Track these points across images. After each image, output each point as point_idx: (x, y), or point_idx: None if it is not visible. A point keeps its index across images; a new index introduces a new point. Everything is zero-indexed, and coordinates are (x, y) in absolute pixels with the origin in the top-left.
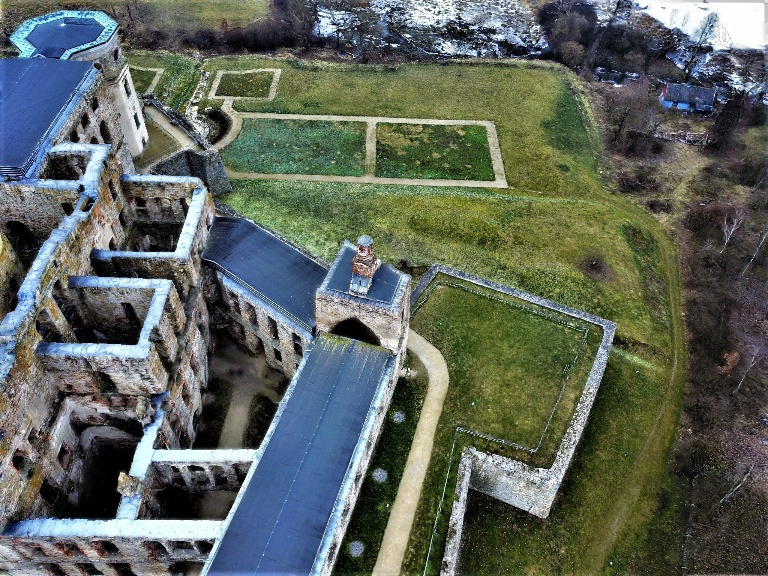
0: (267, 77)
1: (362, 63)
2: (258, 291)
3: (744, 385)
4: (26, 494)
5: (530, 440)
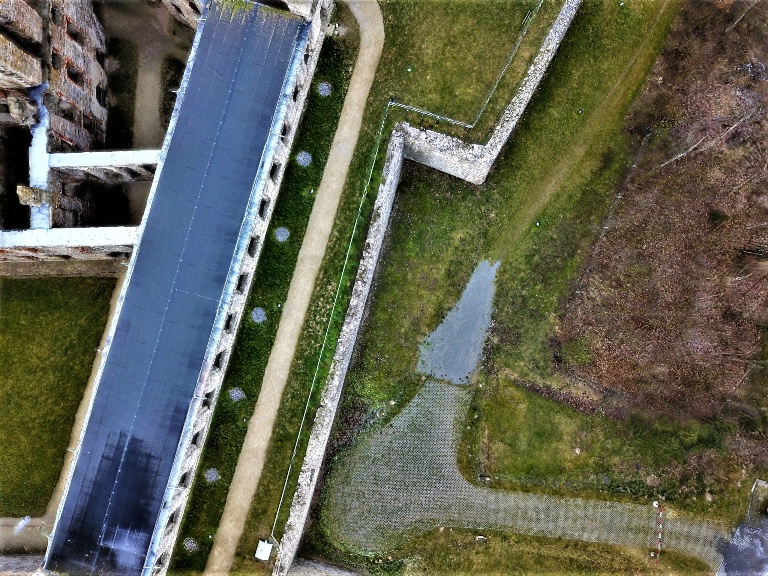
0: None
1: None
2: None
3: (743, 20)
4: None
5: (469, 113)
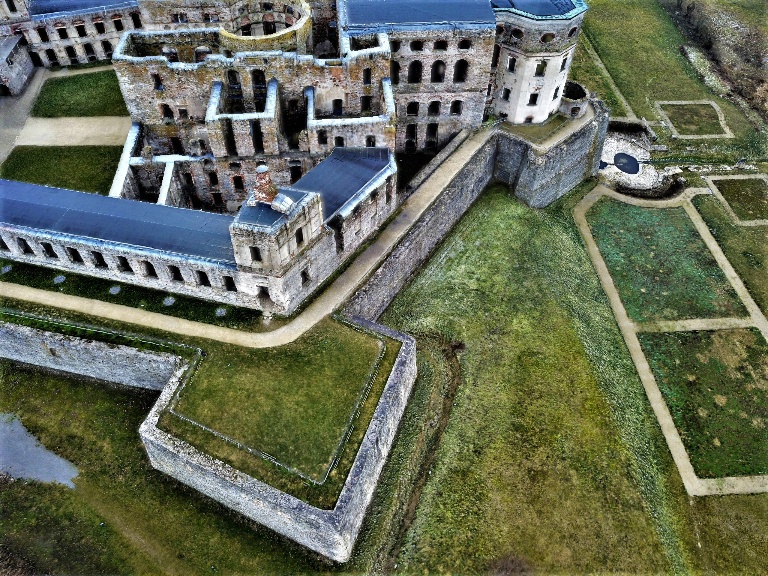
0: None
1: None
2: (299, 179)
3: None
4: (159, 128)
5: (187, 411)
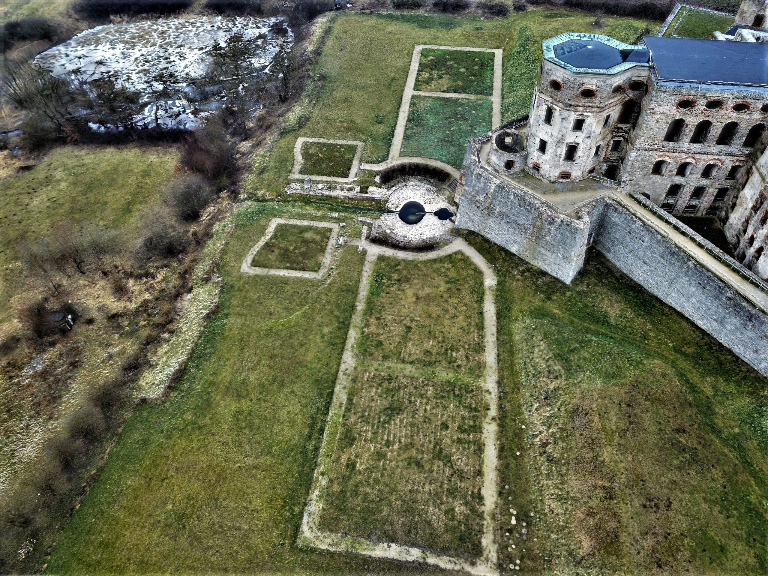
0: (315, 145)
1: (285, 100)
2: None
3: None
4: None
5: None
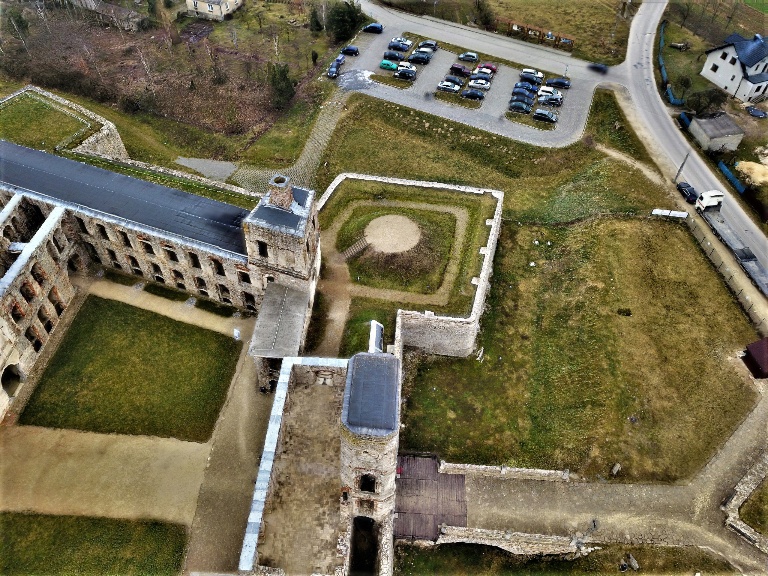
0: None
1: None
2: None
3: None
4: None
5: None
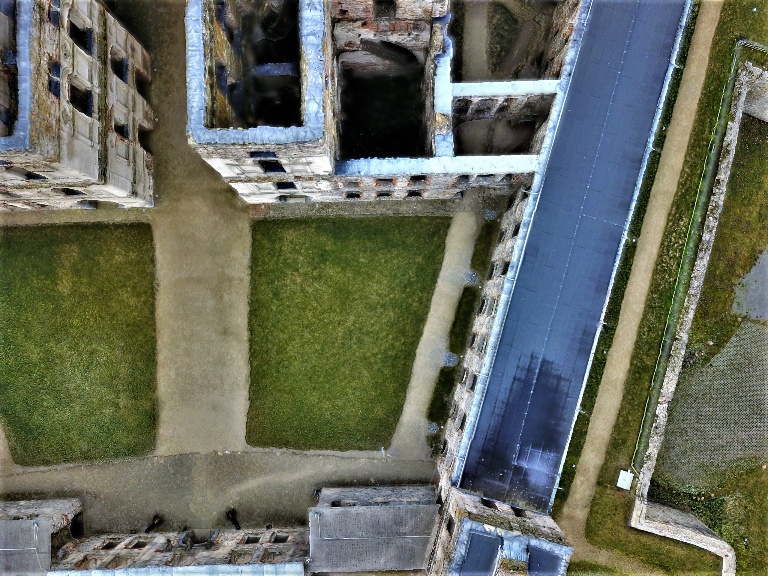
0: None
1: None
2: None
3: None
4: (335, 133)
5: None
